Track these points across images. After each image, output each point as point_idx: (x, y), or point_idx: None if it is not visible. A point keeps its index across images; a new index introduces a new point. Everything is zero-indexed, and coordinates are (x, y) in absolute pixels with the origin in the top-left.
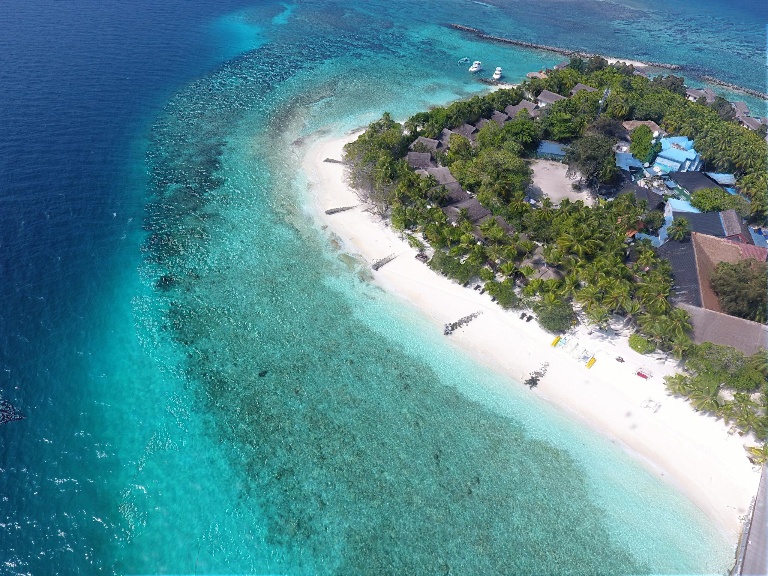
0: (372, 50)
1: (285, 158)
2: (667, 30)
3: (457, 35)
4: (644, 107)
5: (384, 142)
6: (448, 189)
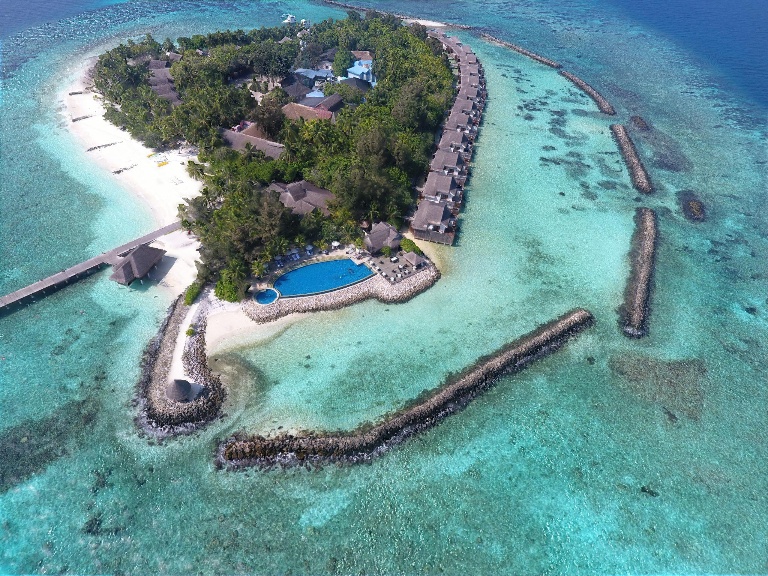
0: (219, 7)
1: (72, 66)
2: (502, 3)
3: (307, 0)
4: (364, 41)
5: (129, 51)
6: (145, 76)
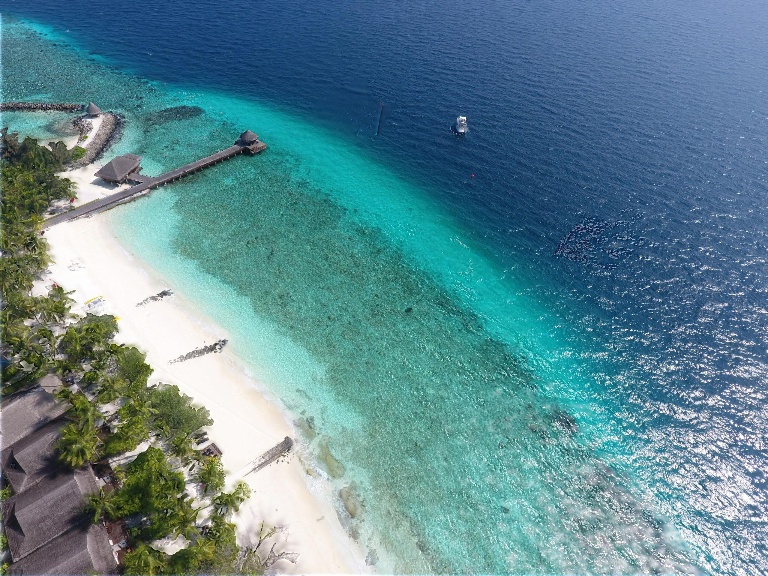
0: None
1: None
2: None
3: None
4: None
5: None
6: None
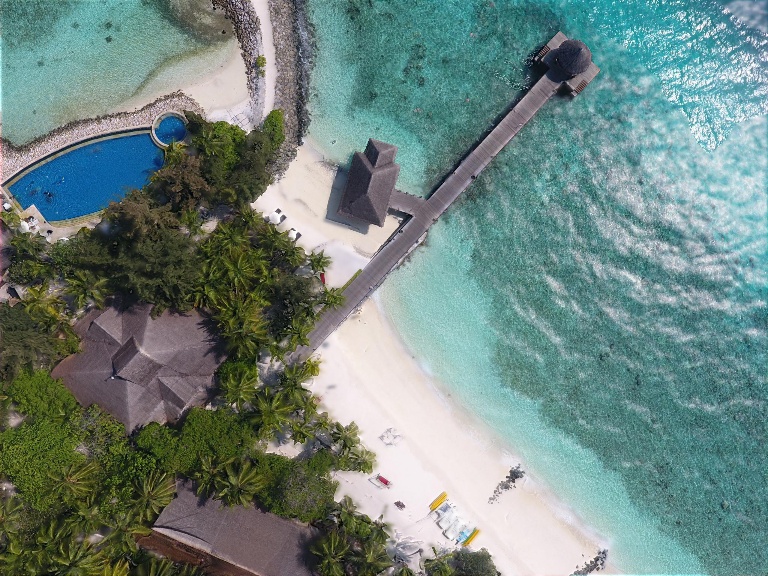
0: None
1: None
2: None
3: None
4: None
5: None
6: None
